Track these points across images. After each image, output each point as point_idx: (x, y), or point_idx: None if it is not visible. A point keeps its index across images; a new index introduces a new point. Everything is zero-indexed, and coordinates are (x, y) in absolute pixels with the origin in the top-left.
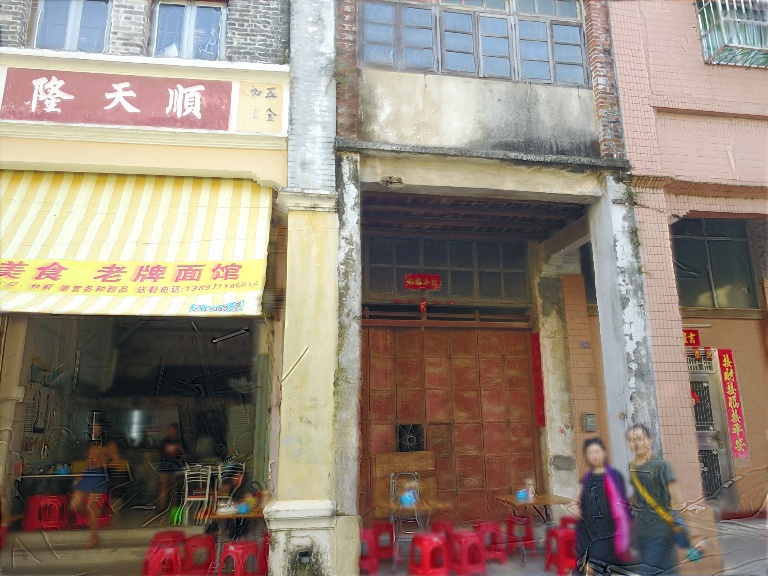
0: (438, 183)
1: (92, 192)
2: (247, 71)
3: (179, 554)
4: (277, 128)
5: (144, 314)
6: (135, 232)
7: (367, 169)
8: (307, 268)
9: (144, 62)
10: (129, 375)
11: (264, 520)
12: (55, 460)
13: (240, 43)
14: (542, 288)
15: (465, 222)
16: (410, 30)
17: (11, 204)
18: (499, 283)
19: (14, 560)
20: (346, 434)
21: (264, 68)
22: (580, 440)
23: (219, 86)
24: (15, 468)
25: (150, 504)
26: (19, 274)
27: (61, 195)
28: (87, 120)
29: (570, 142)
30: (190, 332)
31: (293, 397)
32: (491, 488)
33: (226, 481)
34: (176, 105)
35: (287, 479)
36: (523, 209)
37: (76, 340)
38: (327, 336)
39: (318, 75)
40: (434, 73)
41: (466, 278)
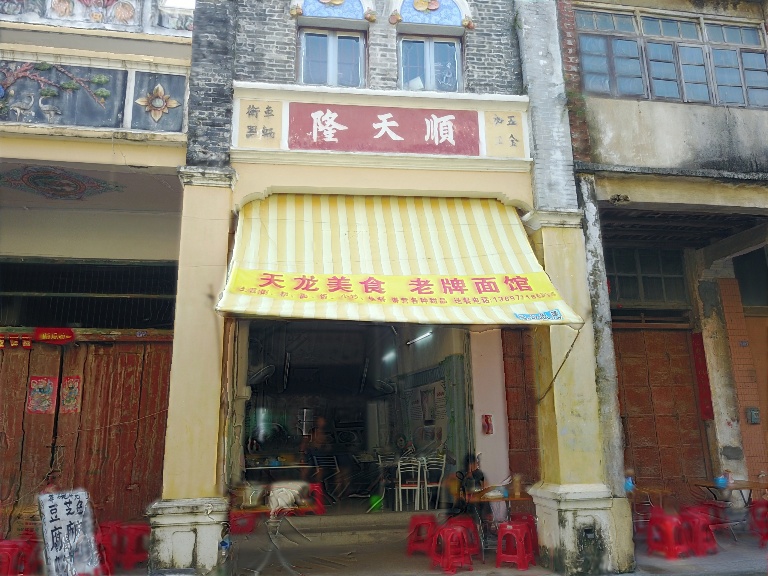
0: (659, 200)
1: (365, 212)
2: (492, 102)
3: (464, 533)
4: (521, 153)
5: (491, 323)
6: (419, 249)
7: (598, 188)
8: (563, 279)
9: (406, 95)
10: (336, 375)
11: (530, 503)
12: (268, 453)
13: (480, 76)
14: (702, 291)
15: (640, 232)
16: (621, 60)
17: (305, 225)
18: (660, 287)
19: (274, 542)
20: (610, 426)
21: (507, 99)
22: (746, 432)
23: (467, 115)
24: (242, 461)
25: (364, 493)
26: (349, 288)
27: (341, 216)
28: (361, 148)
29: (767, 160)
30: (390, 335)
31: (564, 393)
32: (666, 476)
33: (432, 471)
34: (433, 133)
35: (567, 466)
36: (700, 220)
37: (285, 343)
38: (585, 339)
39: (553, 104)
40: (645, 99)
41: (631, 283)
